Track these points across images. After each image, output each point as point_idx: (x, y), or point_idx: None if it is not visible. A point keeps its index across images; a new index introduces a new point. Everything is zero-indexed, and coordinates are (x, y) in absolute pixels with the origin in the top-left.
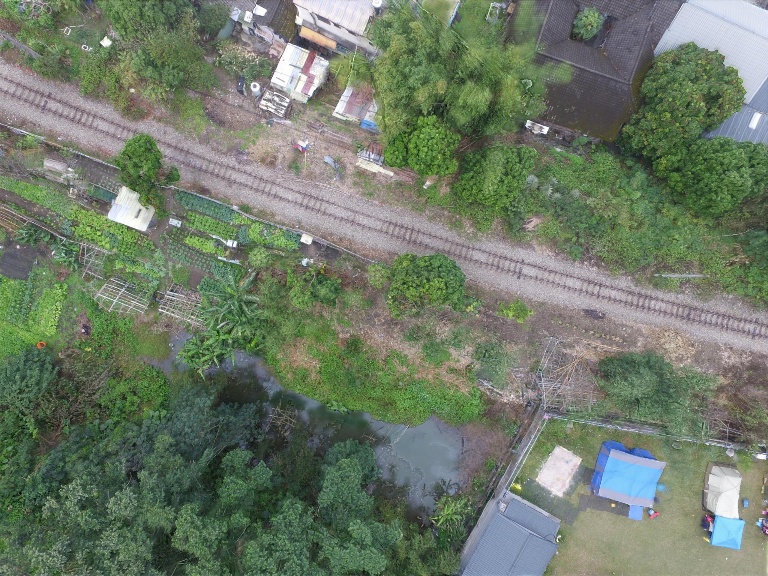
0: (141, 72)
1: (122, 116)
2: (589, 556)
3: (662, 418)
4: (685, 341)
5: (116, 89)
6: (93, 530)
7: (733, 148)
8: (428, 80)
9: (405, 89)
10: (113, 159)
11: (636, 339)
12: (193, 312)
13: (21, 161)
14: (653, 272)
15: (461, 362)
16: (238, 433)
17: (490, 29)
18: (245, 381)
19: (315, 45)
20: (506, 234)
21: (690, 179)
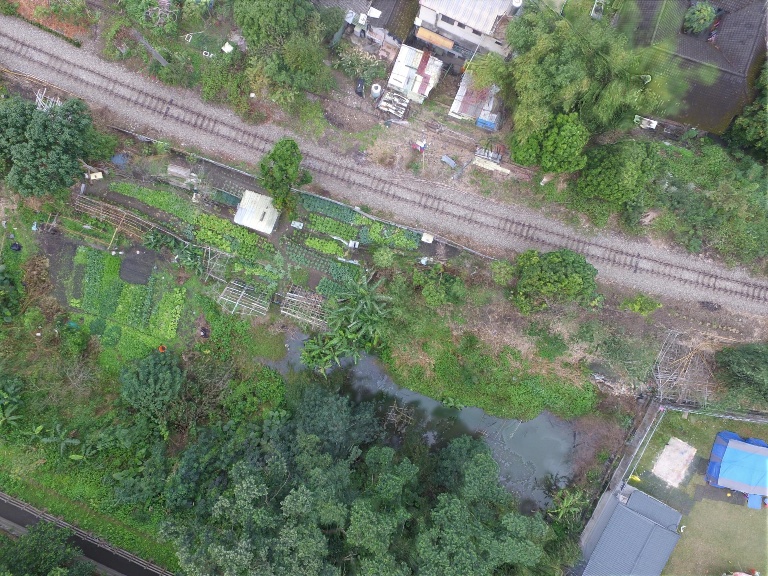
0: (274, 77)
1: (242, 121)
2: (705, 546)
3: None
4: None
5: (238, 94)
6: (269, 528)
7: None
8: (575, 78)
9: (550, 87)
10: (234, 163)
11: (752, 330)
12: (313, 313)
13: (145, 167)
14: None
15: (573, 356)
16: (362, 431)
17: (595, 25)
18: (359, 380)
19: (431, 46)
20: (622, 228)
21: None
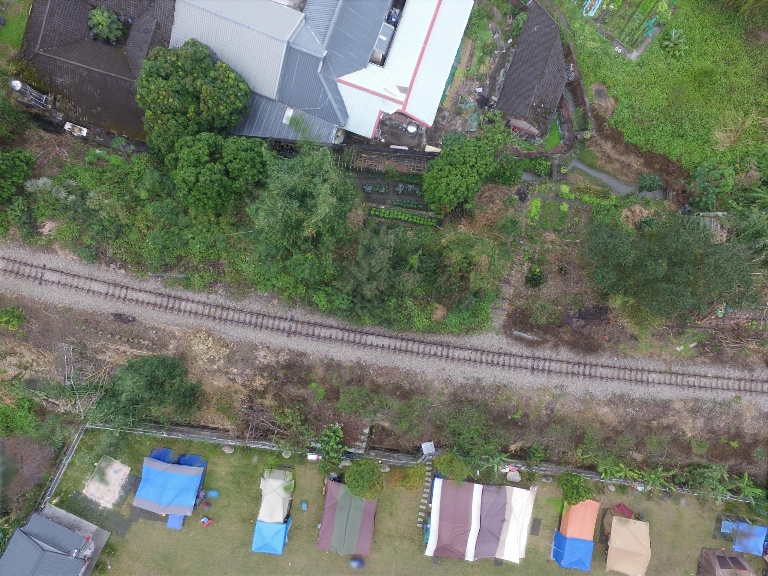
0: None
1: None
2: (144, 569)
3: (224, 422)
4: (217, 342)
5: None
6: None
7: (199, 143)
8: None
9: None
10: None
11: (167, 342)
12: None
13: None
14: (181, 272)
15: (8, 373)
16: None
17: None
18: None
19: None
20: None
21: None
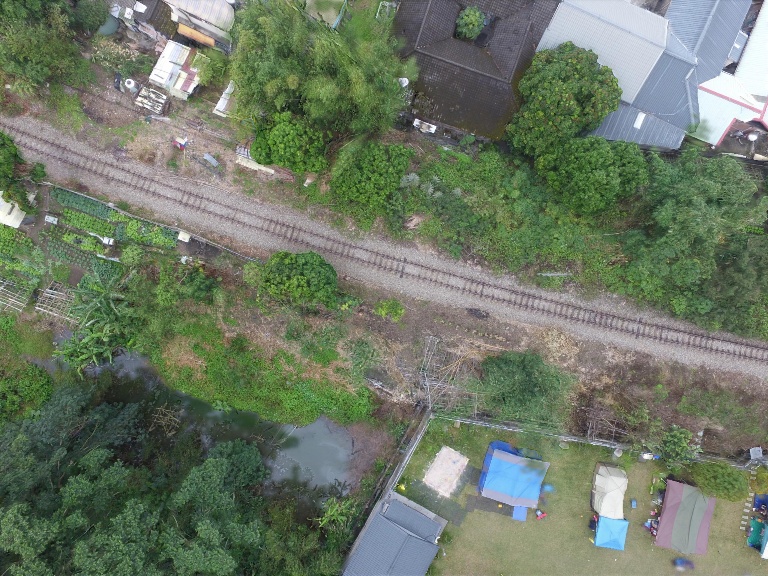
0: (3, 67)
1: None
2: (477, 557)
3: (552, 418)
4: (568, 340)
5: None
6: None
7: (602, 147)
8: (276, 76)
9: (256, 85)
10: None
11: (520, 338)
12: None
13: None
14: (536, 271)
15: (349, 361)
16: (115, 433)
17: (380, 28)
18: (131, 380)
19: (194, 42)
20: (388, 232)
21: (564, 178)
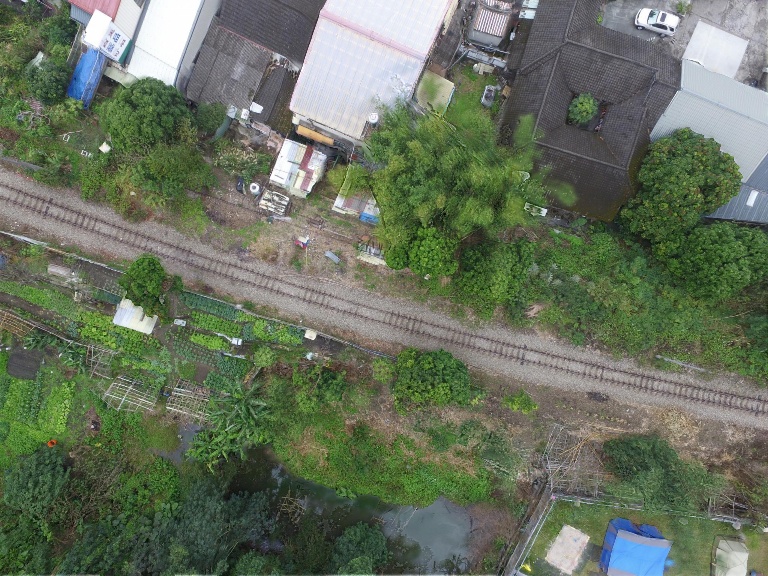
0: (141, 186)
1: (123, 219)
2: None
3: None
4: (689, 420)
5: (117, 194)
6: None
7: (731, 239)
8: (427, 199)
9: (404, 205)
10: (116, 262)
11: (640, 420)
12: (200, 407)
13: (25, 268)
14: (655, 353)
15: None
16: (249, 527)
17: (486, 112)
18: (254, 469)
19: (312, 141)
20: (508, 321)
21: (689, 267)
